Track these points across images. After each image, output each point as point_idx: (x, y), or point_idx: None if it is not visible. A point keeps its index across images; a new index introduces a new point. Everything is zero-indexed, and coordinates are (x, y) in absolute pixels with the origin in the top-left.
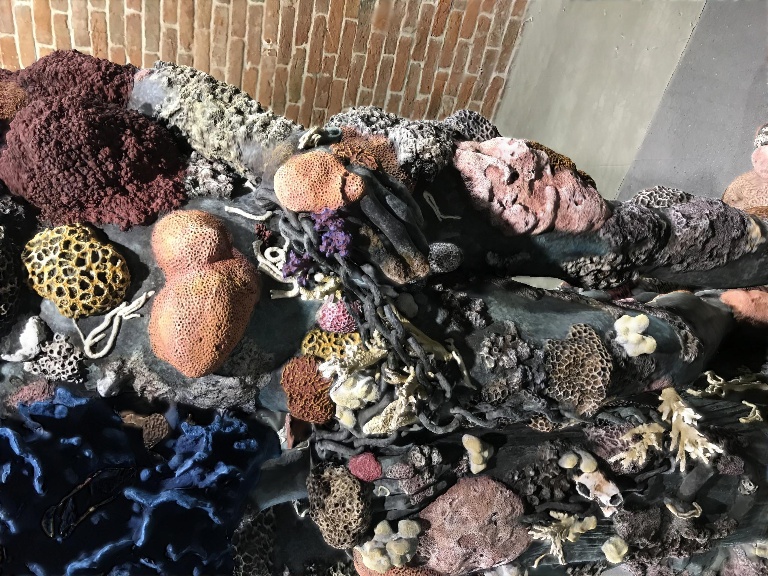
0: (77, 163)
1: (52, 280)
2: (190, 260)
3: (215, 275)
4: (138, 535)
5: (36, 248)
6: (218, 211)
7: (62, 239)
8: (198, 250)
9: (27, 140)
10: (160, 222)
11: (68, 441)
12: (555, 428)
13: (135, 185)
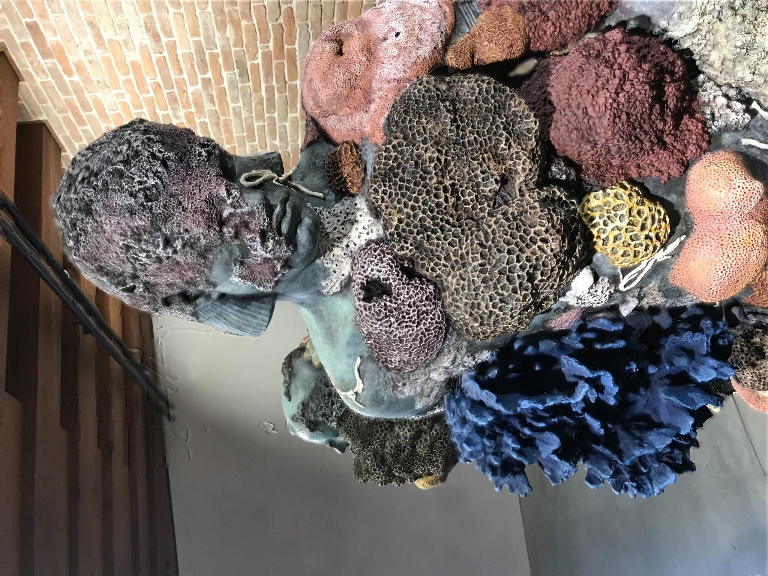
0: (637, 130)
1: (619, 244)
2: (734, 213)
3: (757, 226)
4: (660, 417)
5: (599, 214)
6: (737, 146)
7: (626, 207)
8: (745, 204)
9: (598, 115)
10: (693, 170)
11: (631, 367)
12: None
13: (673, 136)
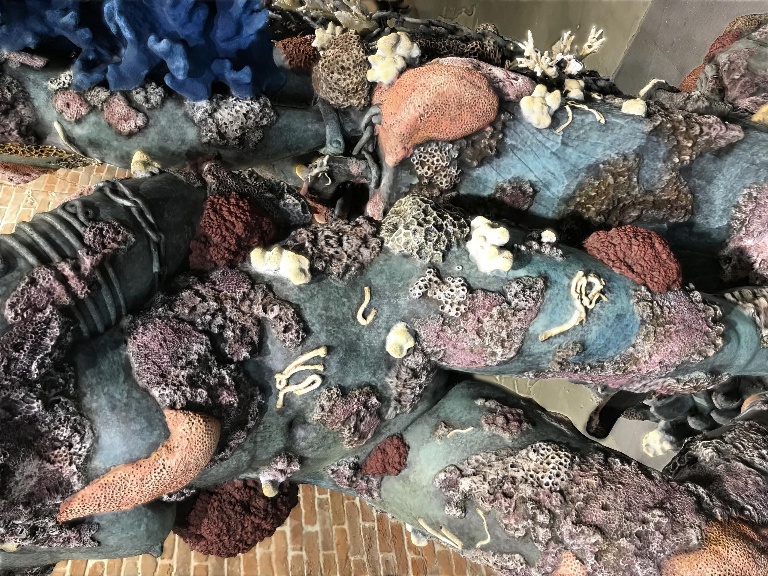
0: None
1: None
2: None
3: None
4: None
5: None
6: None
7: None
8: None
9: None
10: None
11: None
12: (483, 47)
13: None
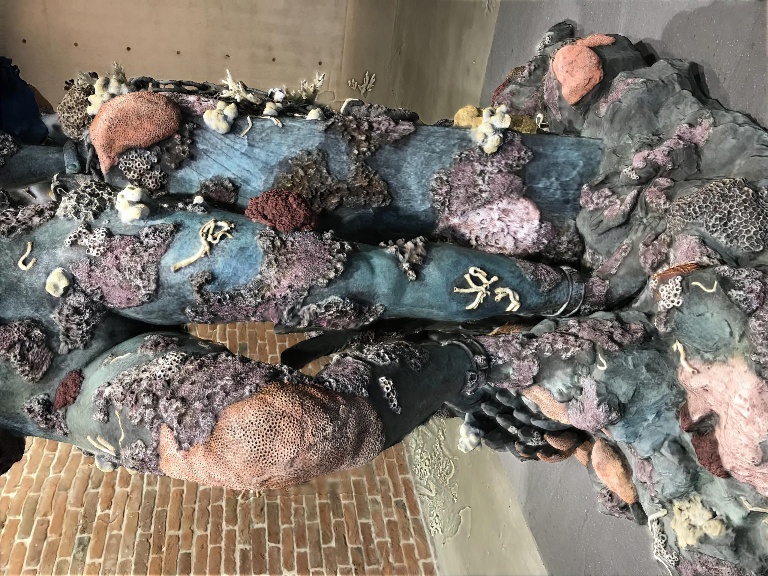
0: None
1: None
2: None
3: None
4: None
5: None
6: None
7: None
8: None
9: None
10: None
11: None
12: None
13: None
